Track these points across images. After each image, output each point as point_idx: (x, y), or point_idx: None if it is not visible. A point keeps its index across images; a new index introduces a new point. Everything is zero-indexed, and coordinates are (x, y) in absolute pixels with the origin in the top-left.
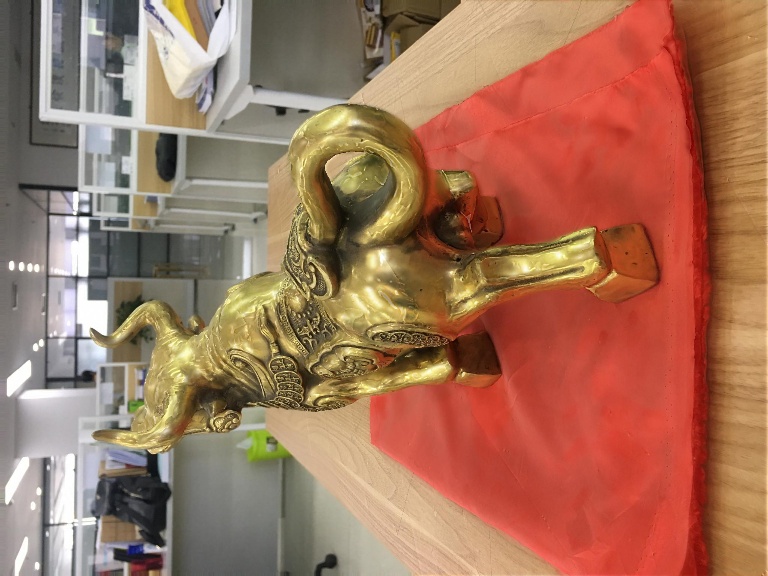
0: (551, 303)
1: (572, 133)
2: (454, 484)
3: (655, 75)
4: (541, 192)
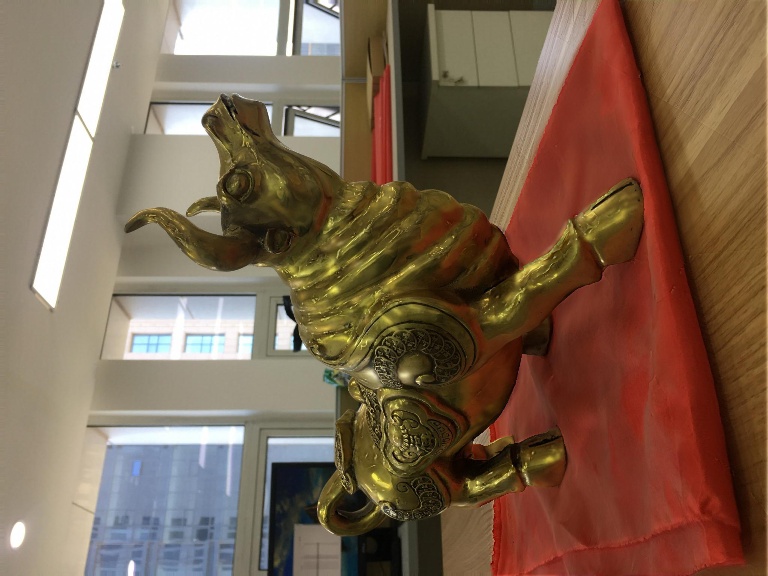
0: (523, 416)
1: (532, 544)
2: (518, 215)
3: (512, 570)
4: (538, 497)
